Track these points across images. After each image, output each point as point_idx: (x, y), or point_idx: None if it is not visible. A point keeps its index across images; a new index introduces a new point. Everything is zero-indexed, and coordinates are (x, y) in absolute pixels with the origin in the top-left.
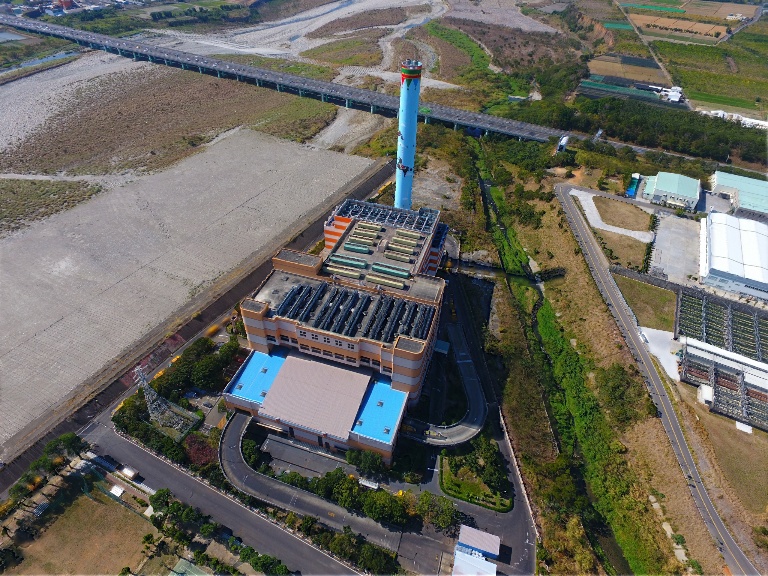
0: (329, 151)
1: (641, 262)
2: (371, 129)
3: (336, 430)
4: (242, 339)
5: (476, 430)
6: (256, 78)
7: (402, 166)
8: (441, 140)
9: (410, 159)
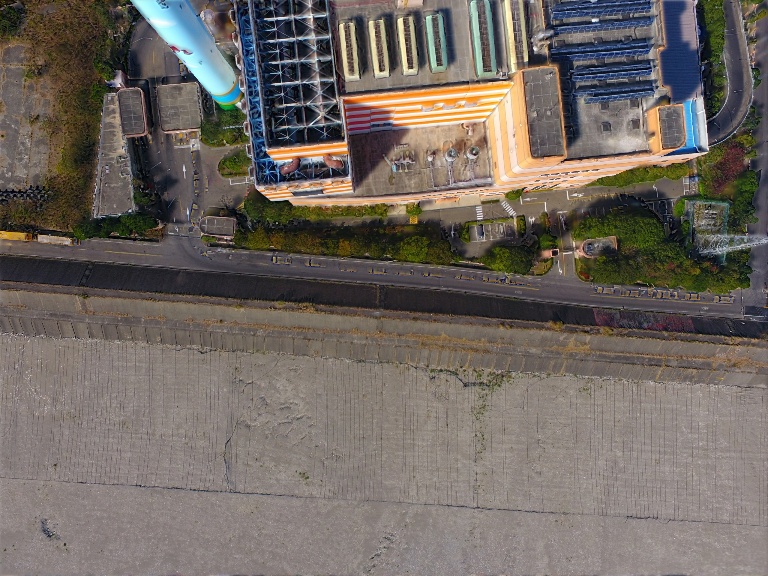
0: None
1: None
2: None
3: None
4: None
5: None
6: None
7: None
8: None
9: None
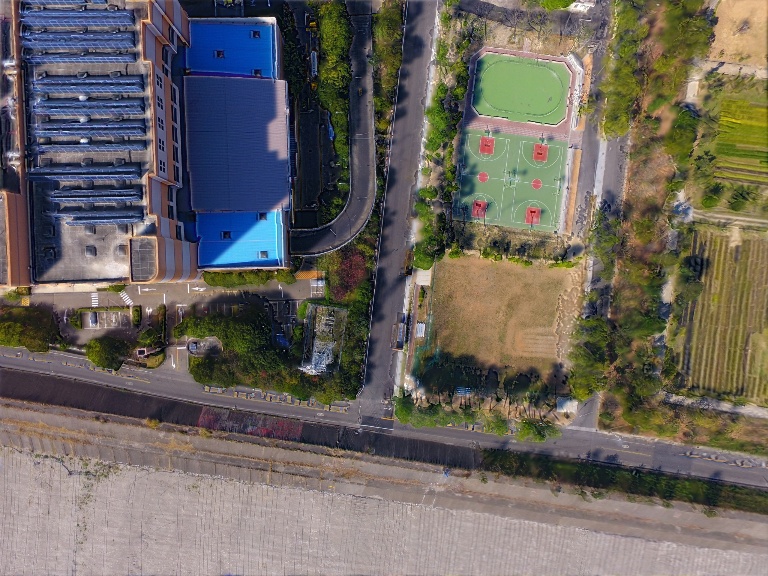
0: None
1: None
2: None
3: (278, 98)
4: (168, 331)
5: None
6: None
7: None
8: None
9: None
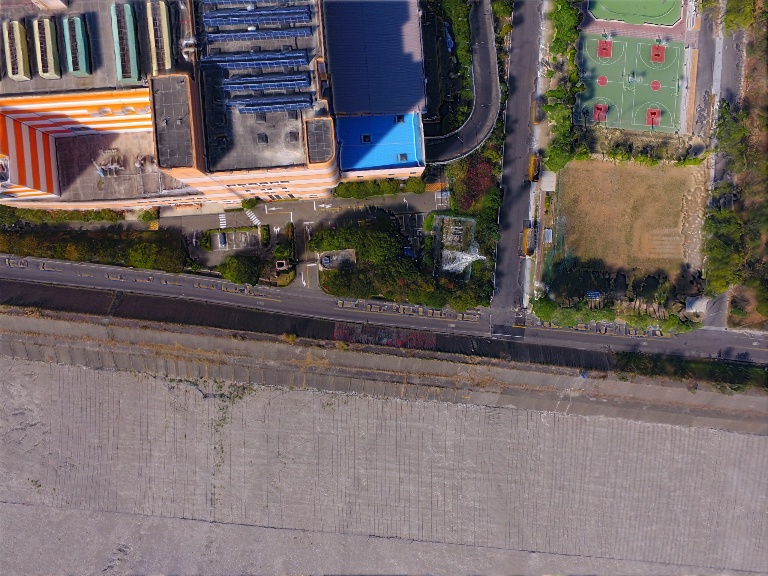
0: None
1: None
2: None
3: (411, 1)
4: (297, 248)
5: None
6: None
7: None
8: None
9: None
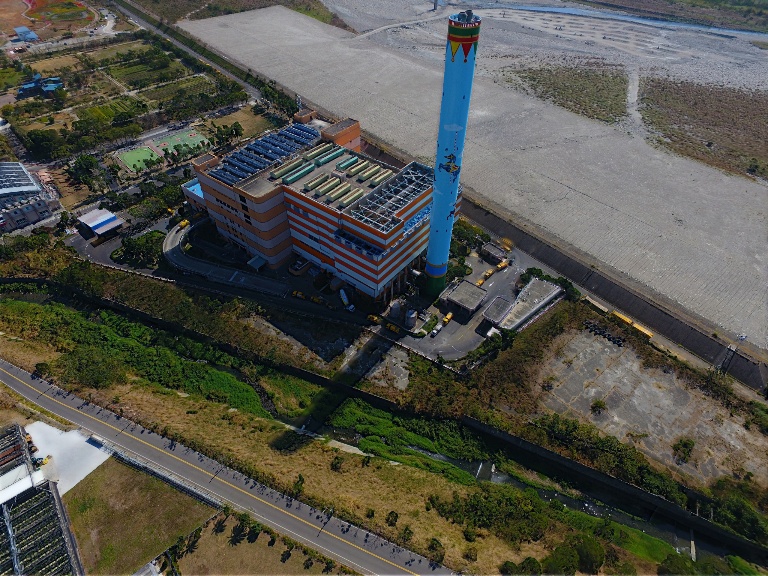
0: None
1: None
2: None
3: None
4: None
5: None
6: None
7: None
8: None
9: None
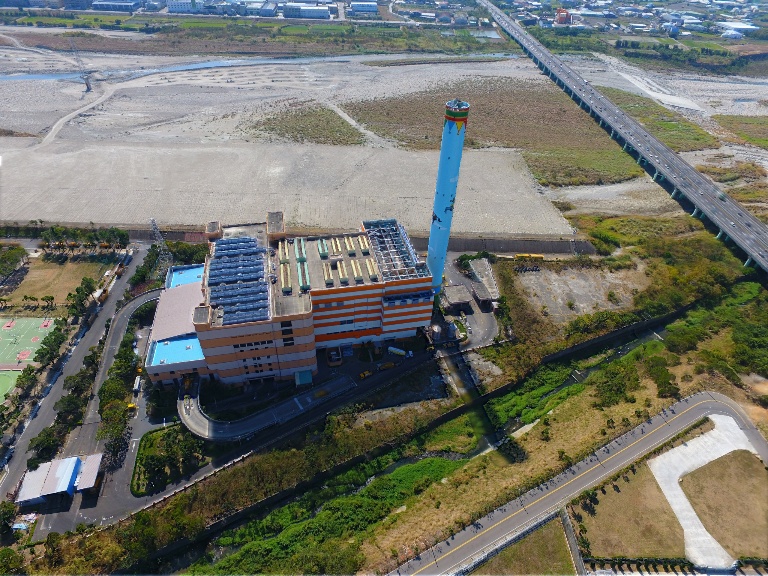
0: (548, 202)
1: (616, 554)
2: (637, 209)
3: (156, 333)
4: None
5: (206, 435)
6: (602, 117)
7: (433, 212)
8: (693, 261)
9: (440, 208)
